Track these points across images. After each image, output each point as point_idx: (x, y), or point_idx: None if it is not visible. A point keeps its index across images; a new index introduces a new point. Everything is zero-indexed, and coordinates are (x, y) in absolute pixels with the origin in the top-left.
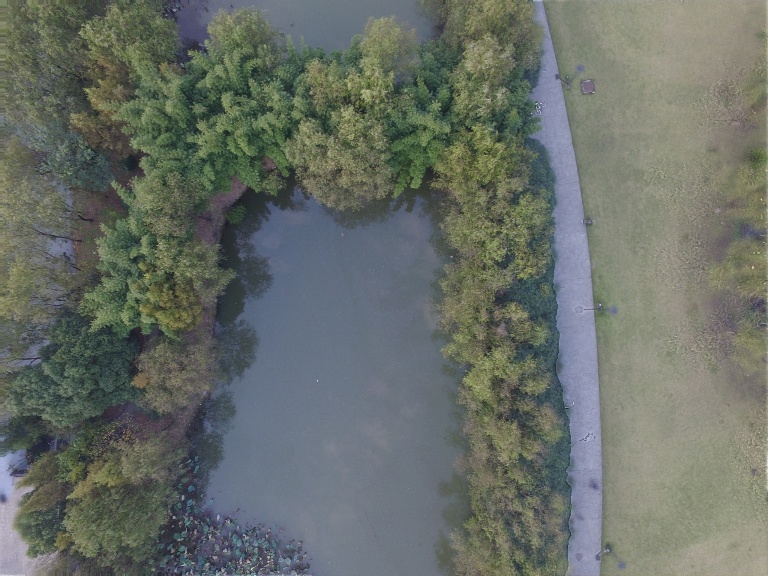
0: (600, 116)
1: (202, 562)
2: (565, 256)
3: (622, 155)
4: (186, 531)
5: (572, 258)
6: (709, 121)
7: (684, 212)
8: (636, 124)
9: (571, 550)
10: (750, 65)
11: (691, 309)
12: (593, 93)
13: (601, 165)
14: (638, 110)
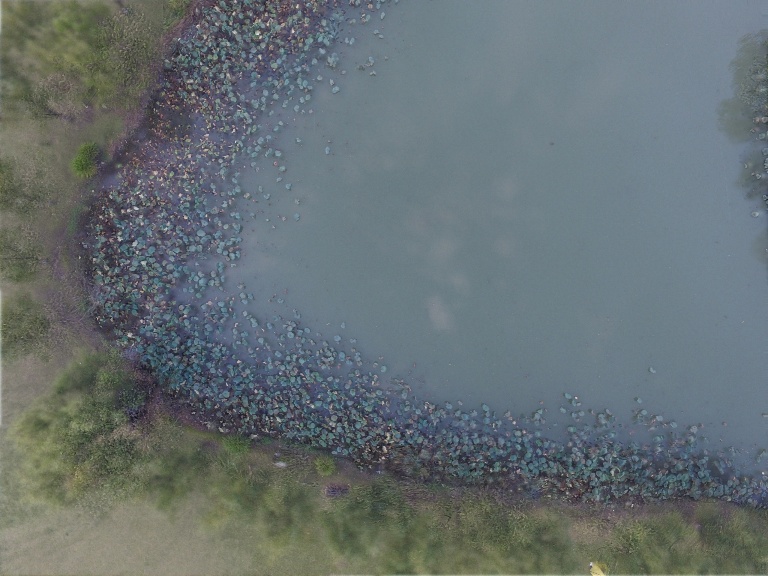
0: None
1: None
2: None
3: None
4: None
5: None
6: (40, 115)
7: (17, 204)
8: None
9: None
10: (81, 61)
11: (22, 298)
12: None
13: None
14: None
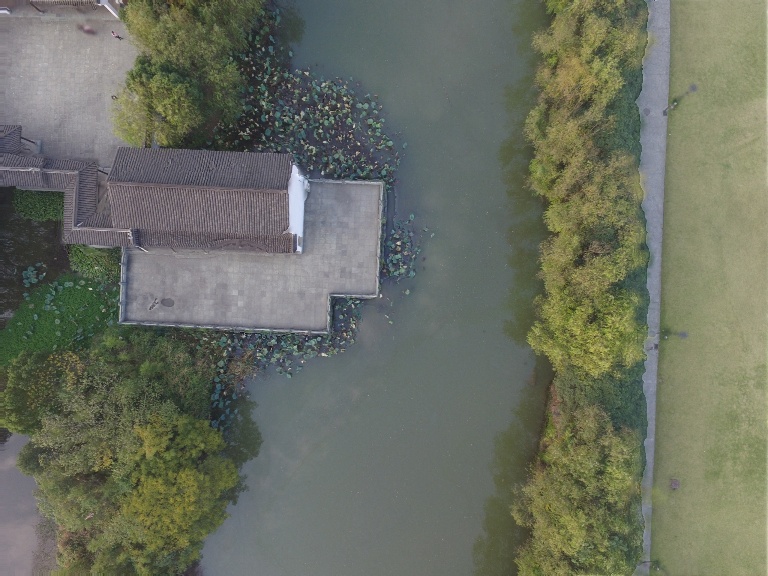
0: None
1: (282, 104)
2: None
3: None
4: (266, 80)
5: None
6: None
7: None
8: None
9: (639, 105)
10: None
11: None
12: None
13: None
14: None
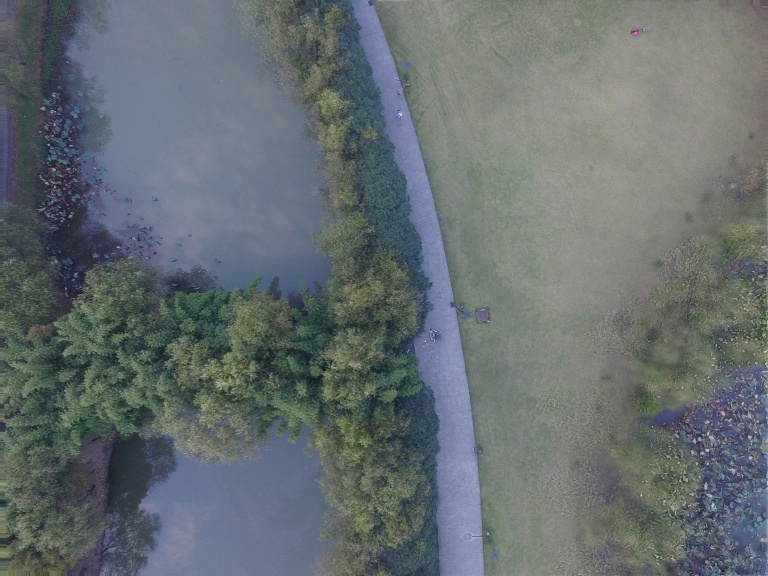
0: (494, 344)
1: None
2: (455, 484)
3: (515, 383)
4: None
5: (462, 486)
6: (603, 349)
7: (576, 438)
8: (530, 353)
9: None
10: (645, 294)
11: (580, 534)
12: (488, 322)
13: (494, 393)
14: (532, 339)
